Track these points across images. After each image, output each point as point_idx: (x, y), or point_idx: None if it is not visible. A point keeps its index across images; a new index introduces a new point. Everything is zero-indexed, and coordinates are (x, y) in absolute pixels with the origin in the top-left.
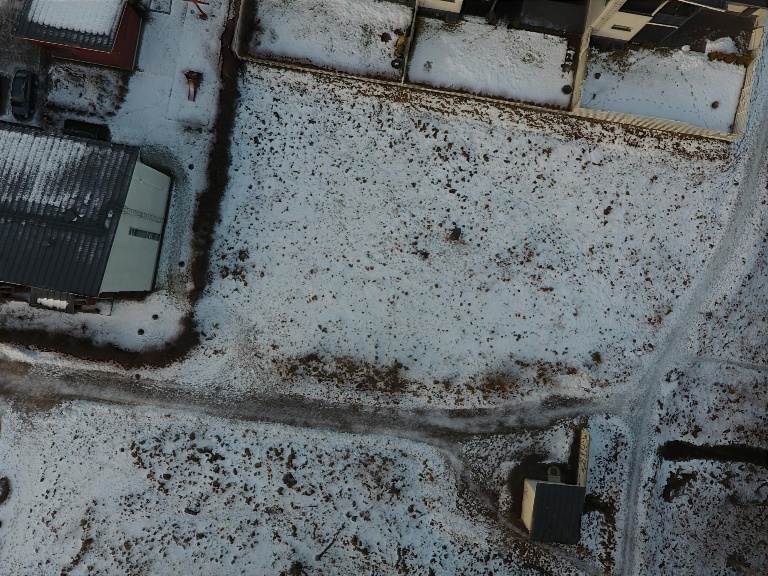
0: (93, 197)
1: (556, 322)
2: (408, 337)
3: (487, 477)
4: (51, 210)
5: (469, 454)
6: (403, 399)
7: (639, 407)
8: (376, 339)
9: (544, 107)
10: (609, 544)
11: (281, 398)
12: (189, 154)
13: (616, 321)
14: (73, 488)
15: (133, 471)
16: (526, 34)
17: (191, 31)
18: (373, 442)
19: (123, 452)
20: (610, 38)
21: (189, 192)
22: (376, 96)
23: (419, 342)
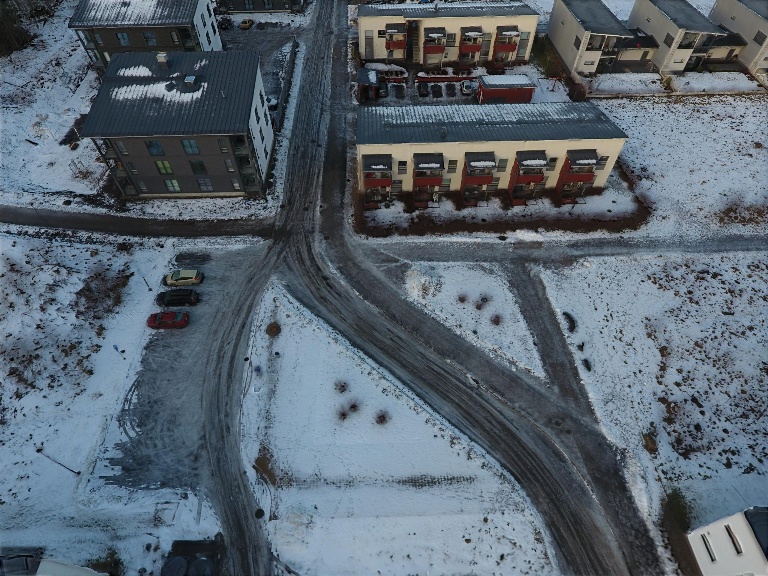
0: None
1: None
2: None
3: None
4: (569, 119)
5: None
6: None
7: None
8: (762, 194)
9: (757, 90)
10: None
11: (727, 237)
12: None
13: None
14: (624, 311)
15: (661, 293)
16: (720, 73)
17: (549, 95)
18: None
19: (645, 282)
20: (762, 68)
21: None
22: (664, 103)
23: None
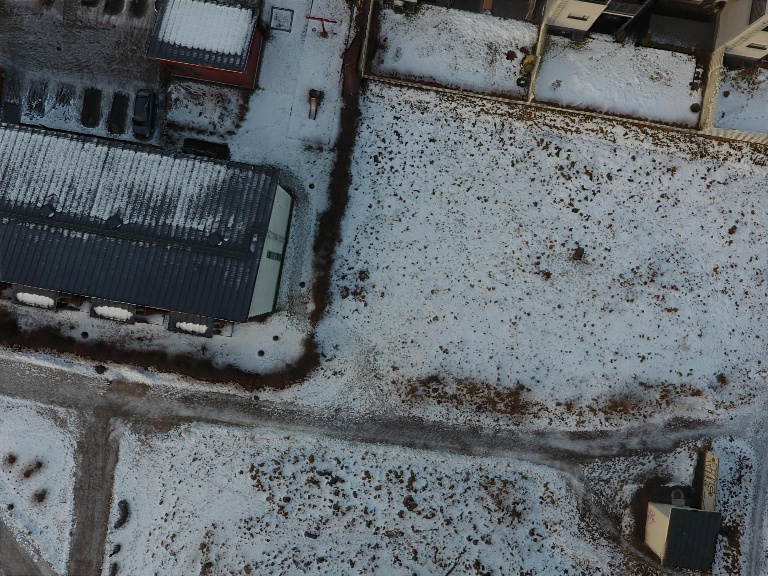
0: (237, 220)
1: (681, 343)
2: (530, 358)
3: (609, 500)
4: (195, 234)
5: (591, 477)
6: (523, 421)
7: (764, 429)
8: (498, 360)
9: (673, 126)
10: (733, 568)
11: (400, 420)
12: (310, 173)
13: (741, 342)
14: (192, 511)
15: (252, 494)
16: (654, 52)
17: (311, 49)
18: (493, 464)
19: (242, 475)
20: (740, 56)
21: (310, 212)
22: (499, 114)
23: (542, 363)
